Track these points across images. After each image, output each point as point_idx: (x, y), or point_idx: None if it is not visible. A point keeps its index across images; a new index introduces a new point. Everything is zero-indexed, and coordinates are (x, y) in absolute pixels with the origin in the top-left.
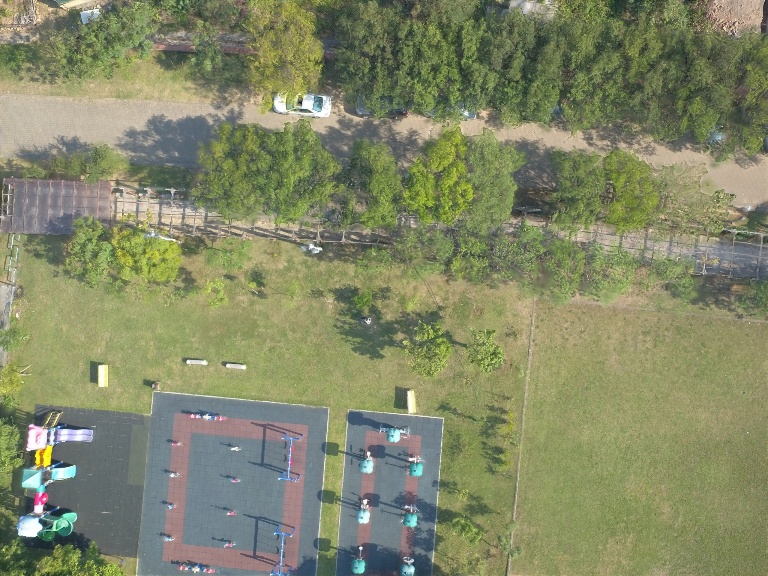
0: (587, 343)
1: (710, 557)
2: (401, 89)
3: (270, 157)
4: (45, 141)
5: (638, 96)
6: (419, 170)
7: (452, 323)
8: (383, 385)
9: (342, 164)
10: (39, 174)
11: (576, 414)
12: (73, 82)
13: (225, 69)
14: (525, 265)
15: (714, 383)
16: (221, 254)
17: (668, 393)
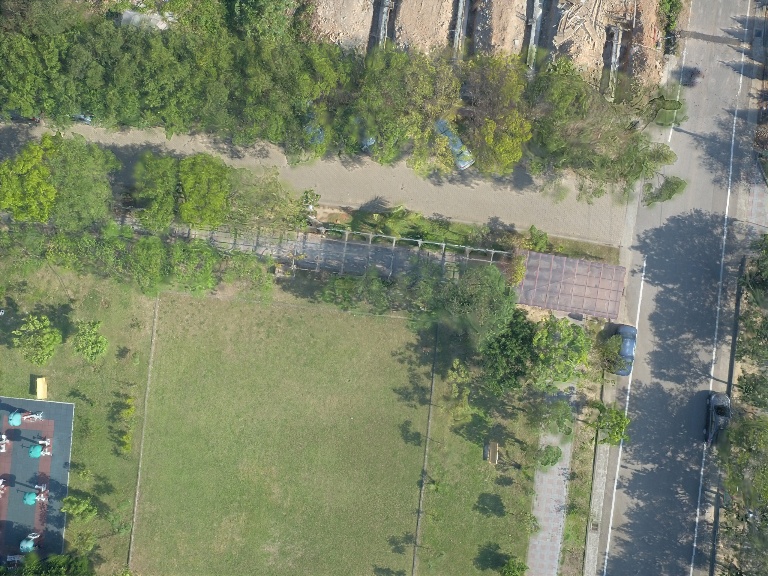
0: (206, 334)
1: (316, 535)
2: (1, 97)
3: None
4: None
5: (207, 103)
6: (5, 172)
7: (82, 315)
8: (19, 373)
9: None
10: None
11: (194, 400)
12: None
13: None
14: (111, 260)
15: (322, 371)
16: None
17: (279, 381)
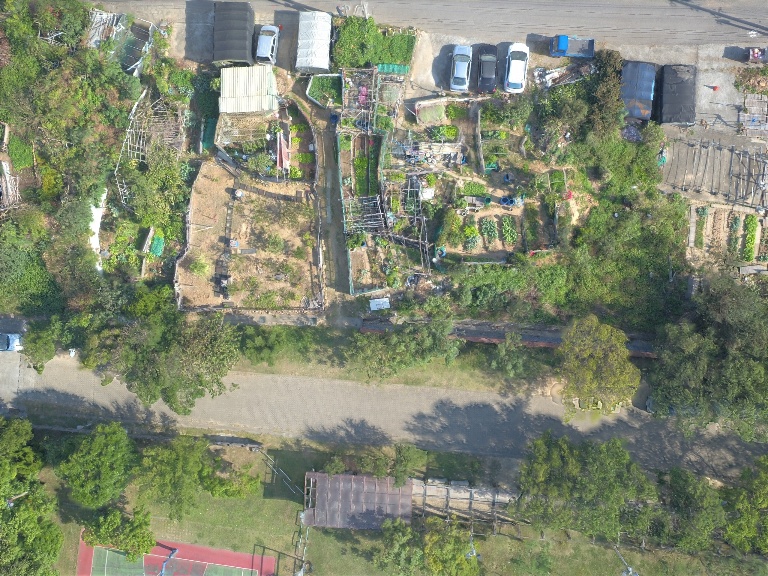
0: None
1: None
2: None
3: (592, 485)
4: (334, 423)
5: None
6: (743, 506)
7: None
8: None
9: (650, 480)
10: (340, 468)
11: None
12: (361, 366)
13: (522, 369)
14: None
15: None
16: (509, 540)
17: None
